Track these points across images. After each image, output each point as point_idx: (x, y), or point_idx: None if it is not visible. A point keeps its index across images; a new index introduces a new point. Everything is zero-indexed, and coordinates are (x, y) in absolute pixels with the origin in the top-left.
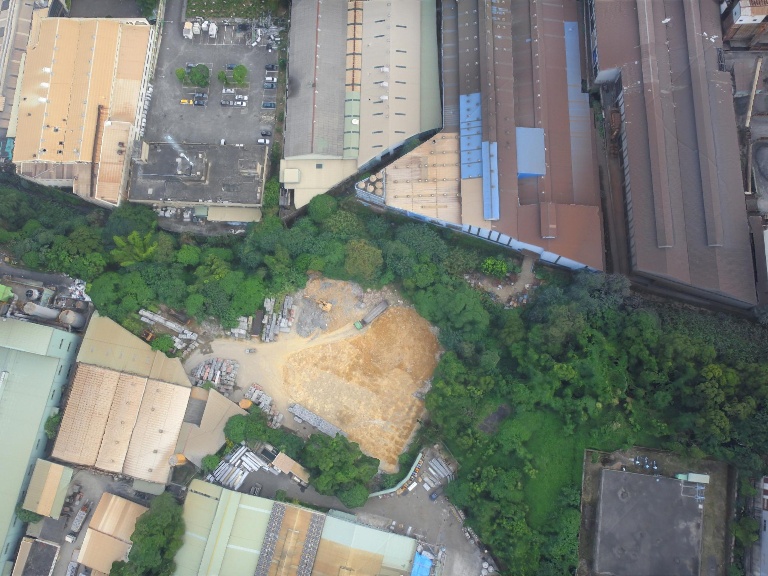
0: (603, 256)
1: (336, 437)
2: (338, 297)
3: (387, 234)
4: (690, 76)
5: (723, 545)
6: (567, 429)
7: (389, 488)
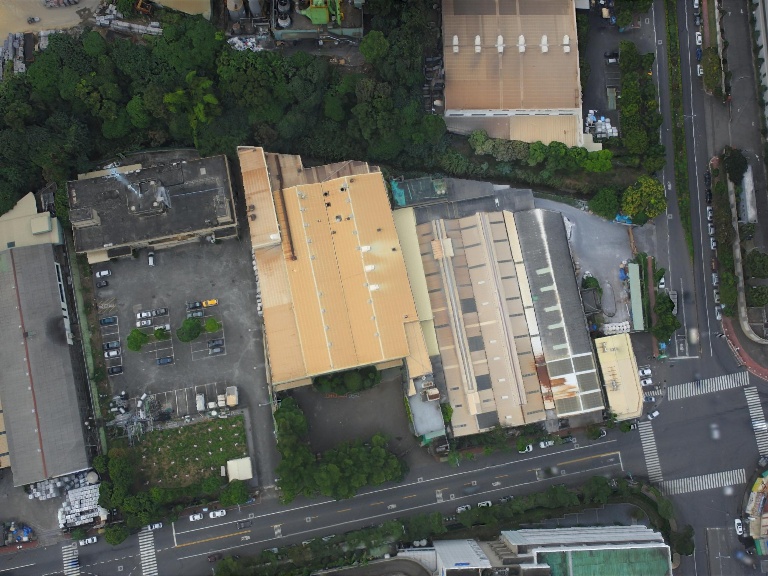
0: None
1: None
2: None
3: None
4: None
5: None
6: None
7: None
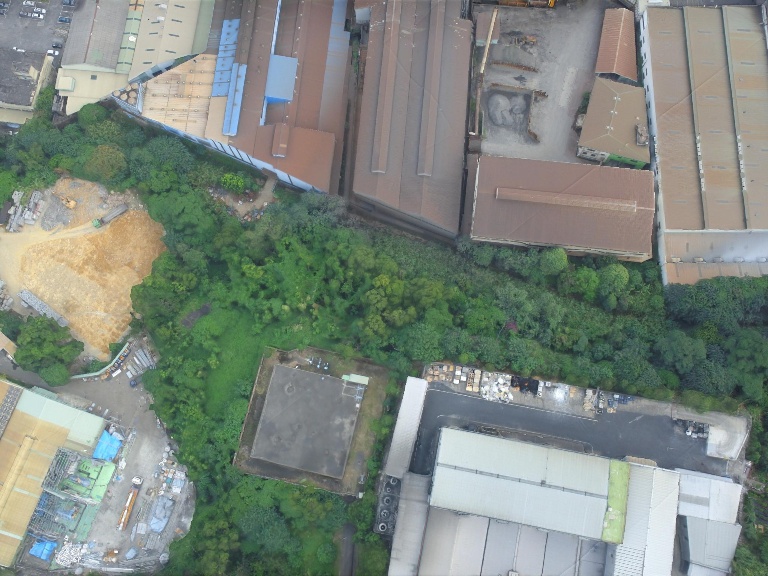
0: (337, 182)
1: (42, 317)
2: (84, 197)
3: (144, 144)
4: (429, 19)
5: (373, 443)
6: (254, 327)
7: (93, 372)
